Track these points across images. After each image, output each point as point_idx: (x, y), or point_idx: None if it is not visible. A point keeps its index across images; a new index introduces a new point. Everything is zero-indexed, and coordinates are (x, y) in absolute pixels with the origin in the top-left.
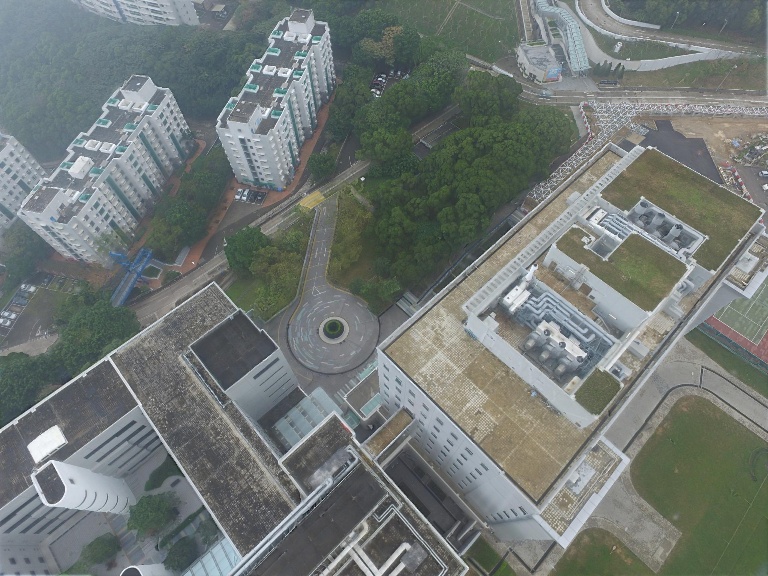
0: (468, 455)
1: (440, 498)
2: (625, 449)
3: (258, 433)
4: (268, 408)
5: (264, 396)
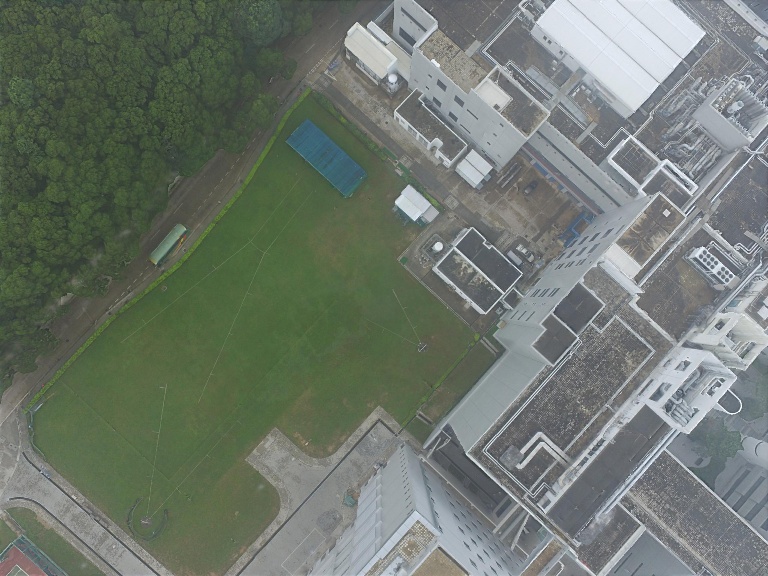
0: (484, 568)
1: (453, 467)
2: (280, 529)
3: (662, 544)
4: (634, 544)
5: (651, 567)
